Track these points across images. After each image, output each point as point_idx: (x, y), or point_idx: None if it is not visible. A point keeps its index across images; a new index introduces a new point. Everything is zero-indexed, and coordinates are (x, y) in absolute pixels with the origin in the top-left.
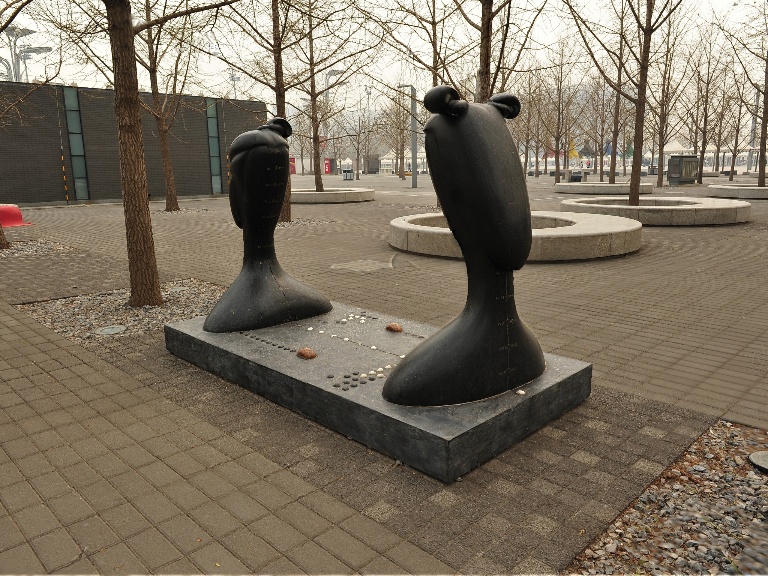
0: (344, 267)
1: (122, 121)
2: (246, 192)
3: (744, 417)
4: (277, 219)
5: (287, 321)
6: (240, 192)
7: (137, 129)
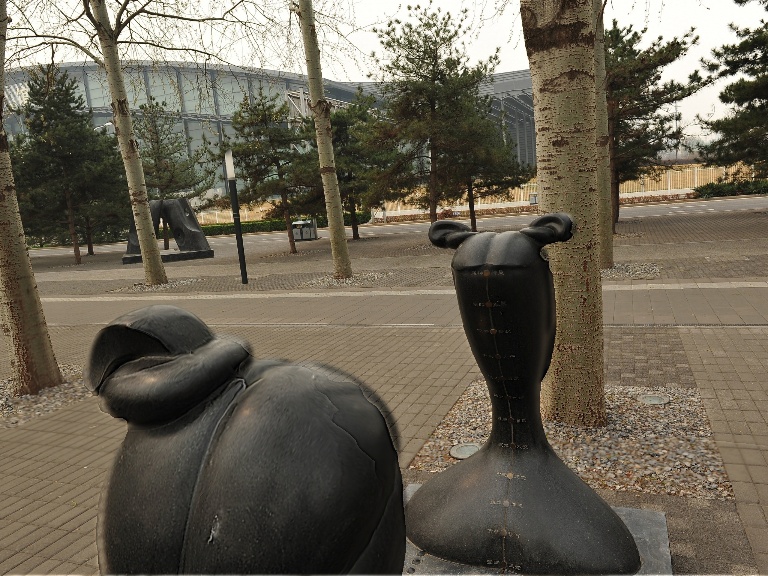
0: None
1: None
2: None
3: (399, 461)
4: None
5: None
6: None
7: None
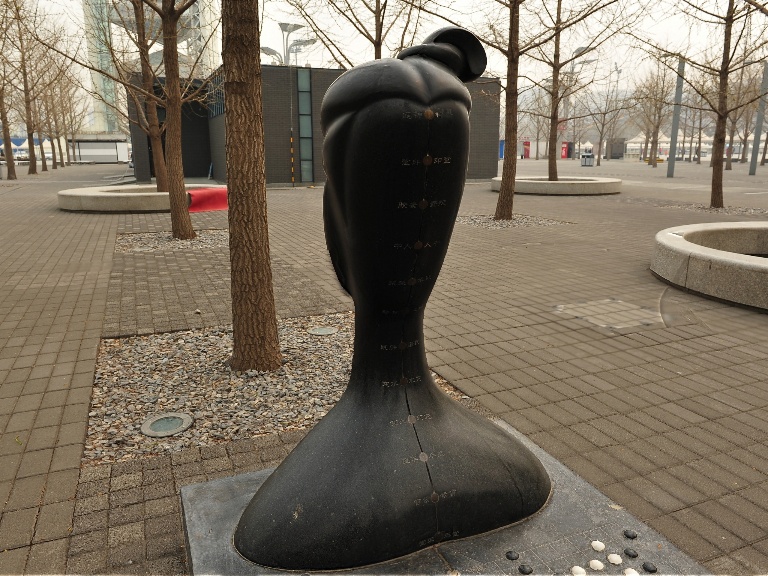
0: (579, 313)
1: (228, 76)
2: (350, 220)
3: None
4: (429, 285)
5: (429, 542)
6: (340, 218)
7: (251, 89)
